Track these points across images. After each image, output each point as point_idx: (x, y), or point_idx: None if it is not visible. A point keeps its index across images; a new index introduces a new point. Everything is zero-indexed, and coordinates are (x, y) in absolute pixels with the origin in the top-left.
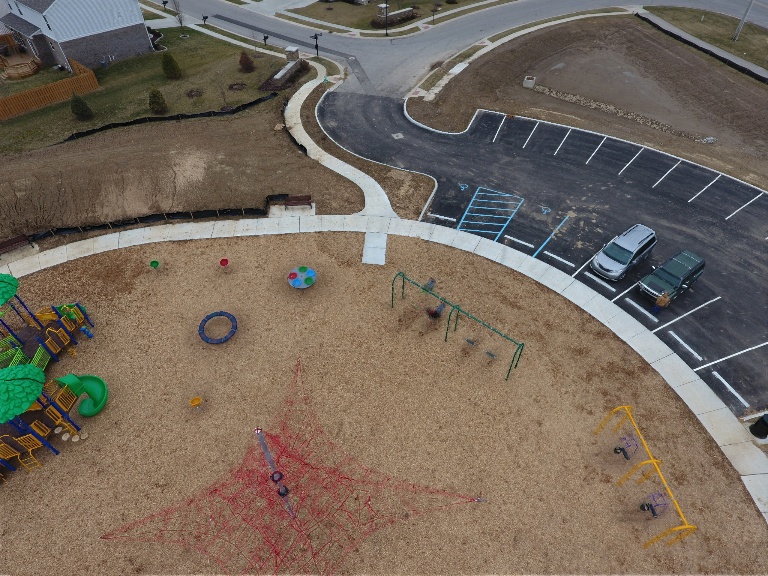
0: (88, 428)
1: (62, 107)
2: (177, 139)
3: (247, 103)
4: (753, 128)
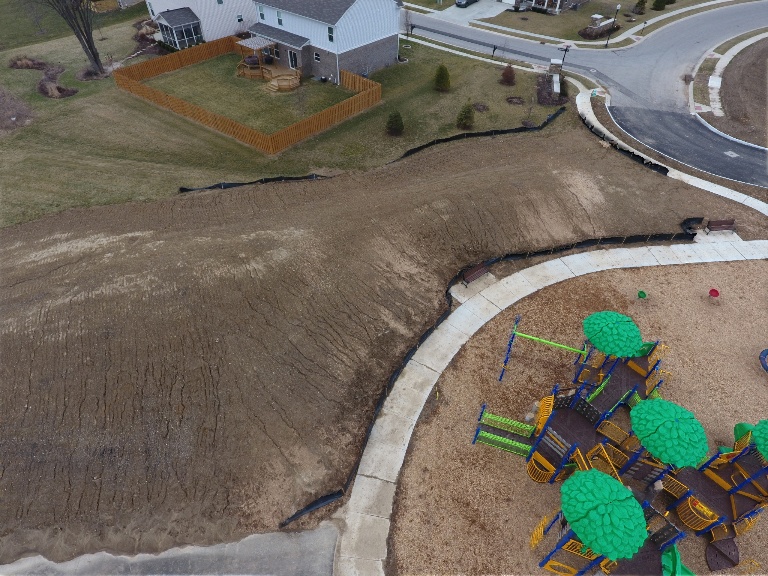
0: None
1: (362, 121)
2: (540, 158)
3: None
4: None
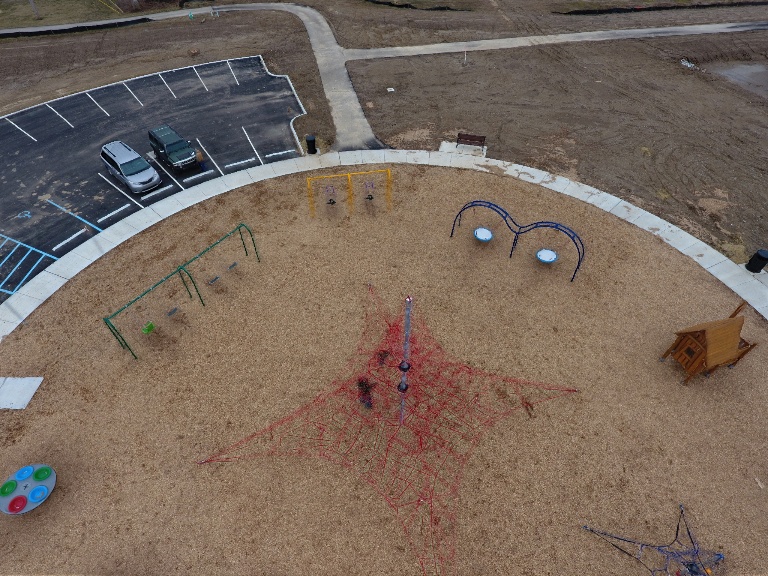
0: None
1: None
2: None
3: None
4: None
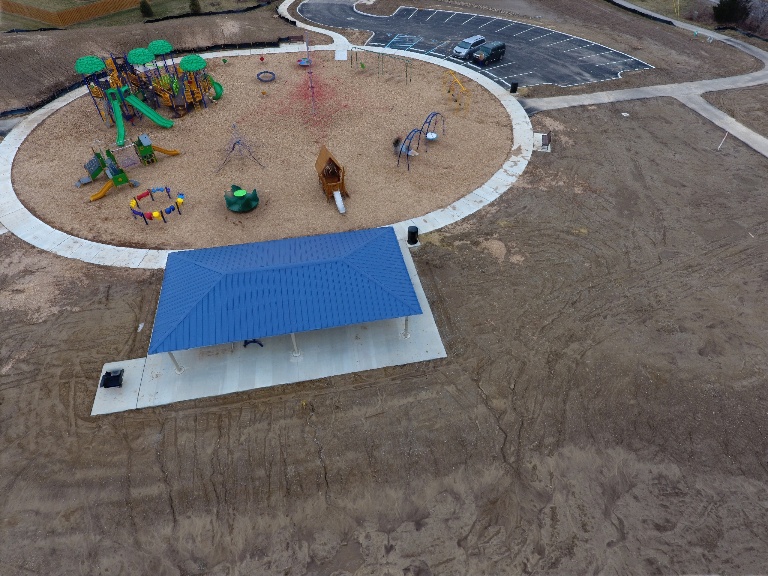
0: None
1: (130, 11)
2: (217, 17)
3: (252, 7)
4: (565, 11)
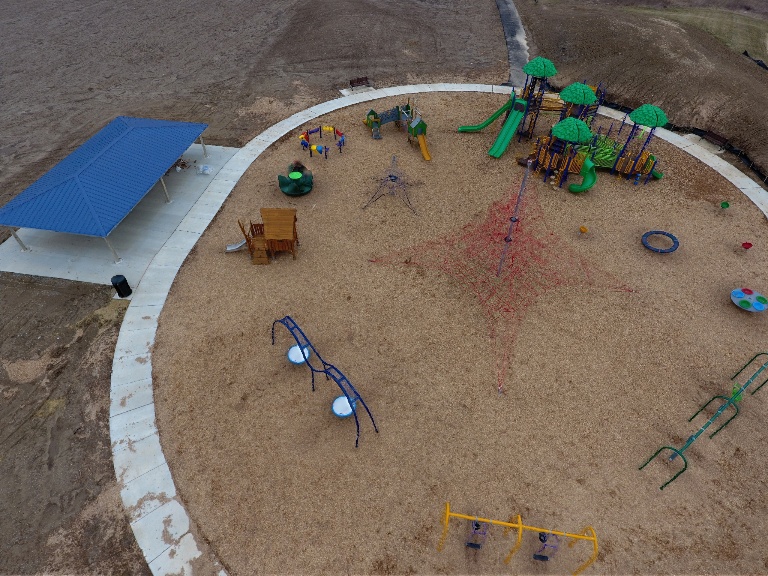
0: (561, 190)
1: None
2: None
3: None
4: None
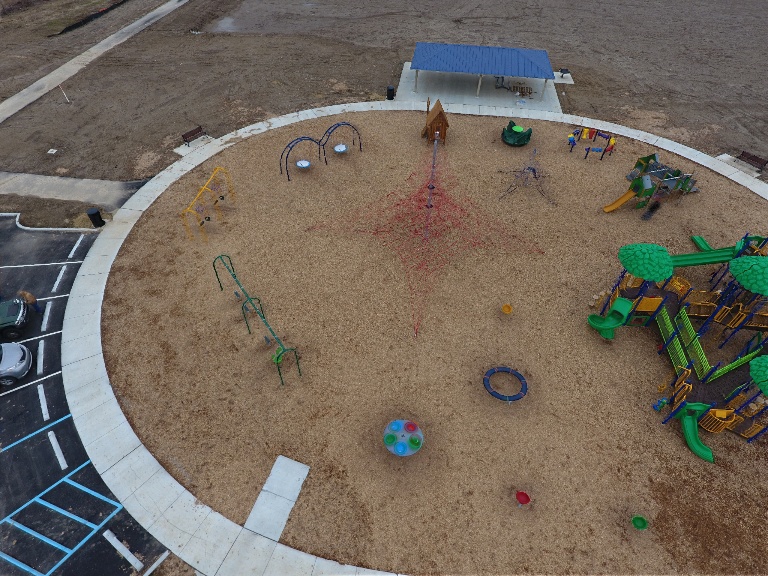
0: None
1: None
2: None
3: None
4: None
